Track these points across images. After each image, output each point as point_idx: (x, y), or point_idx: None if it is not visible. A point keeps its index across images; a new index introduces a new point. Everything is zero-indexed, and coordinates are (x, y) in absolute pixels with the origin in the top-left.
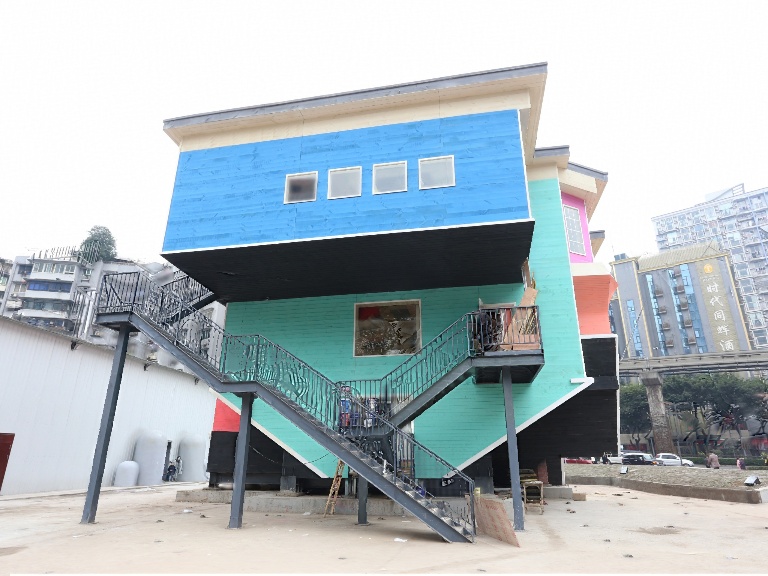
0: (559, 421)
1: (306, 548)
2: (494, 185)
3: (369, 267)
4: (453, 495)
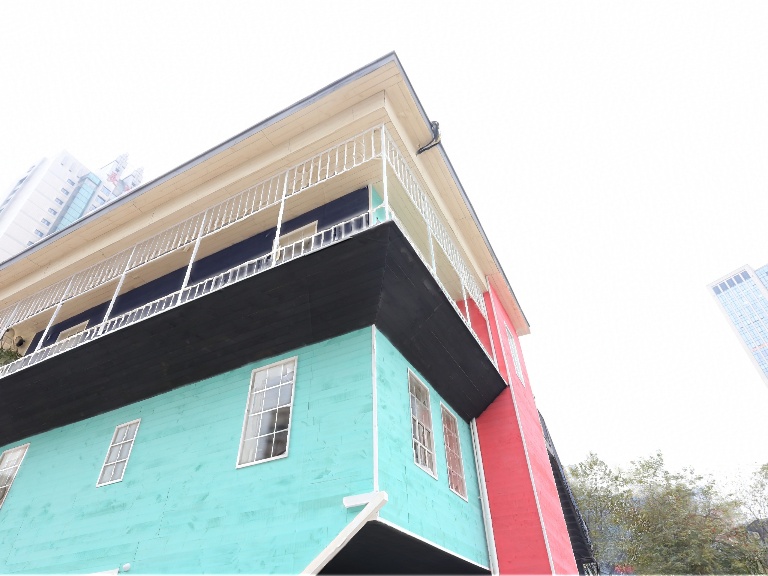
0: None
1: None
2: None
3: None
4: None
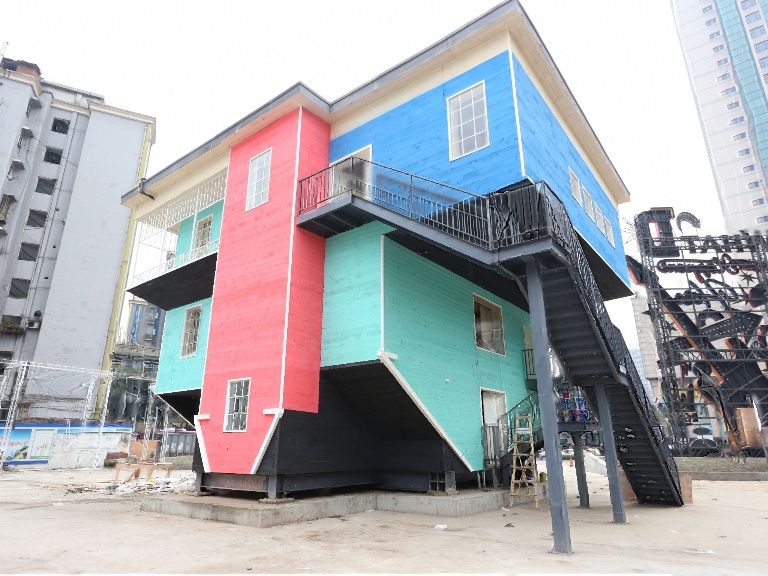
0: None
1: (732, 519)
2: None
3: None
4: None
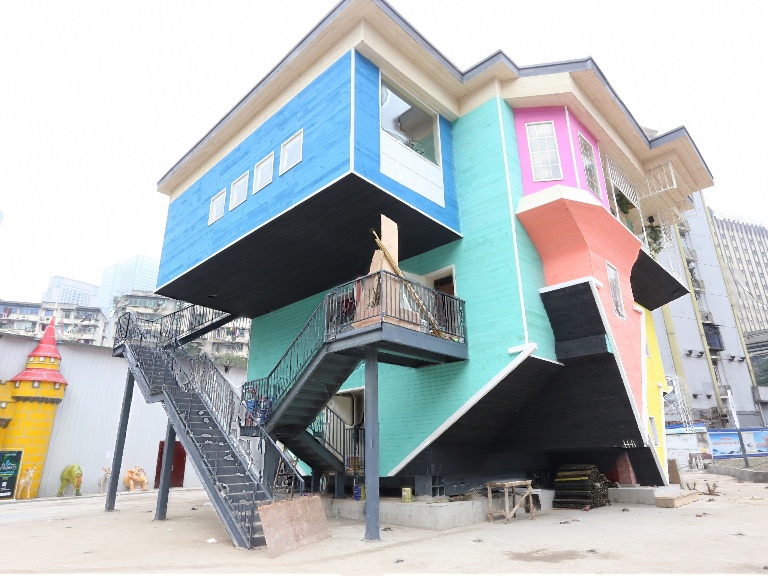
0: (553, 402)
1: (111, 541)
2: (328, 146)
3: (294, 264)
4: (401, 496)
